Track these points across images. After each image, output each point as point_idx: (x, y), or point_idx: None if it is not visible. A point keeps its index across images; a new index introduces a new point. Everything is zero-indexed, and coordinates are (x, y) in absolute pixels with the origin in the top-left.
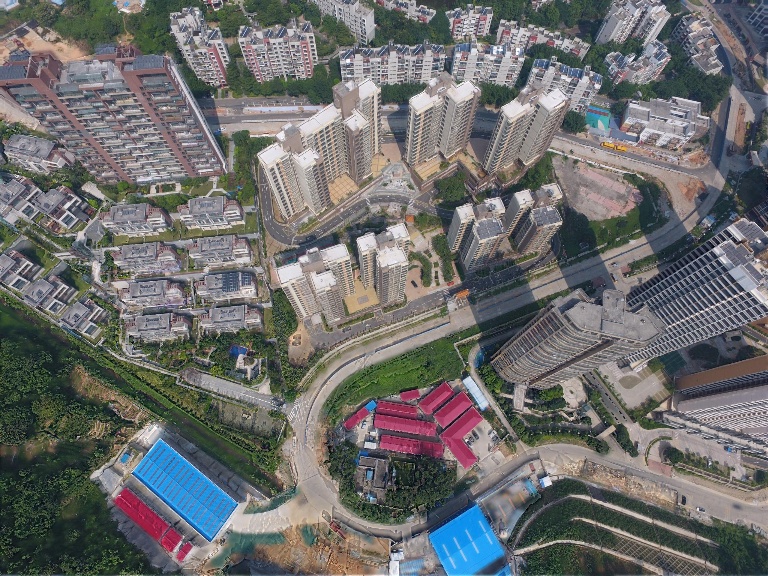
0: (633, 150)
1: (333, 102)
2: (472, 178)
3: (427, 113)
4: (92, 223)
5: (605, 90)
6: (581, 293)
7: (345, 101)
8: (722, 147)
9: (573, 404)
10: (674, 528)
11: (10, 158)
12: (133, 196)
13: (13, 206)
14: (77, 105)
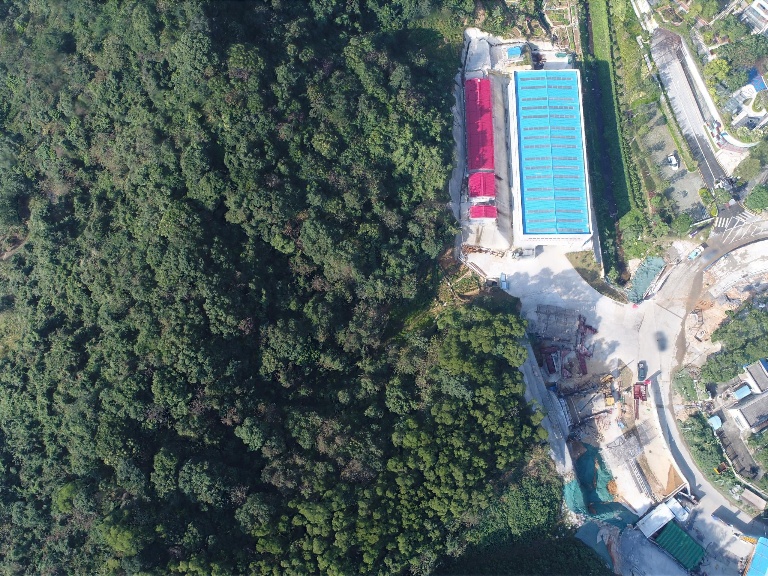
0: None
1: None
2: None
3: None
4: None
5: None
6: None
7: None
8: None
9: None
10: None
11: None
12: None
13: None
14: None
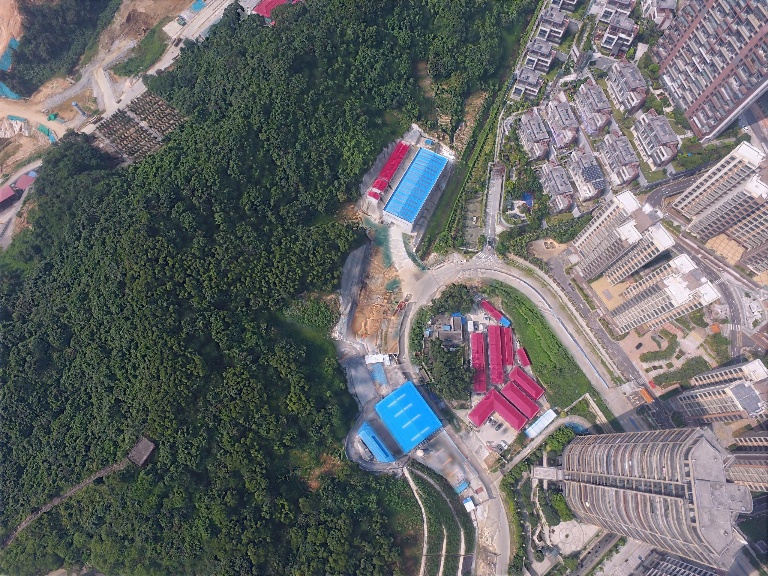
0: None
1: None
2: None
3: None
4: (611, 59)
5: None
6: (732, 458)
7: None
8: None
9: (554, 538)
10: None
11: None
12: None
13: (608, 3)
14: None
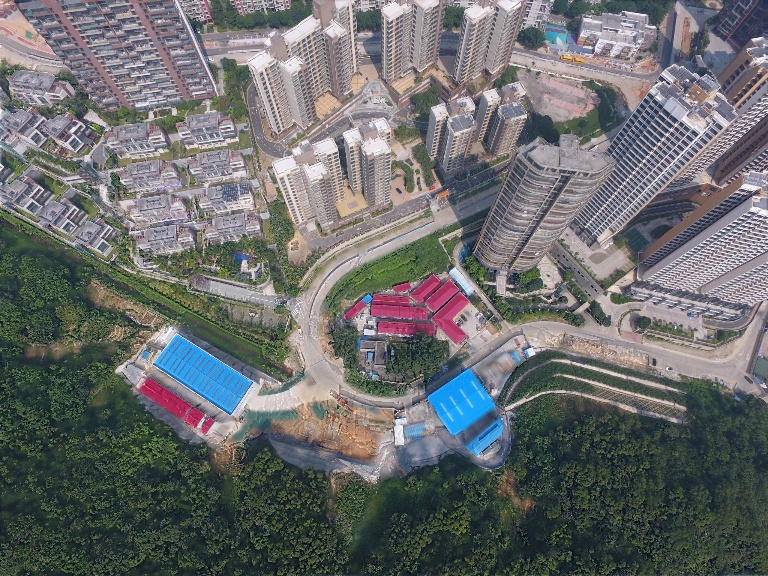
0: (590, 61)
1: (312, 14)
2: (444, 90)
3: (398, 21)
4: (97, 147)
5: (561, 9)
6: (541, 139)
7: (323, 10)
8: (670, 54)
9: (550, 286)
10: (646, 382)
11: (14, 95)
12: (134, 118)
13: (22, 133)
14: (80, 20)
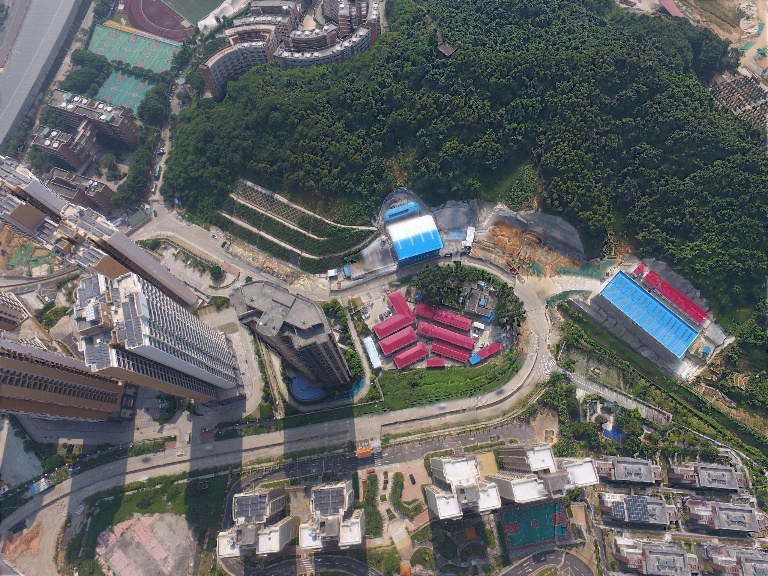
0: None
1: None
2: None
3: None
4: None
5: None
6: (298, 340)
7: None
8: None
9: None
10: (245, 226)
11: None
12: None
13: None
14: None
